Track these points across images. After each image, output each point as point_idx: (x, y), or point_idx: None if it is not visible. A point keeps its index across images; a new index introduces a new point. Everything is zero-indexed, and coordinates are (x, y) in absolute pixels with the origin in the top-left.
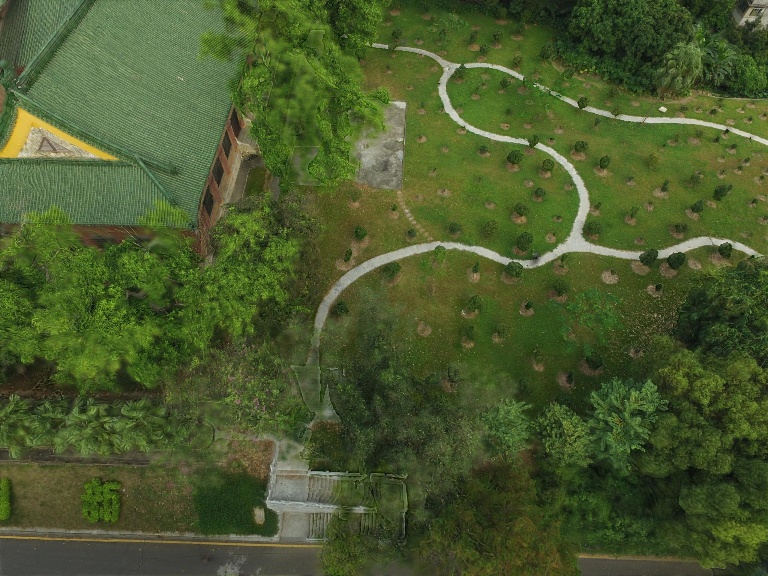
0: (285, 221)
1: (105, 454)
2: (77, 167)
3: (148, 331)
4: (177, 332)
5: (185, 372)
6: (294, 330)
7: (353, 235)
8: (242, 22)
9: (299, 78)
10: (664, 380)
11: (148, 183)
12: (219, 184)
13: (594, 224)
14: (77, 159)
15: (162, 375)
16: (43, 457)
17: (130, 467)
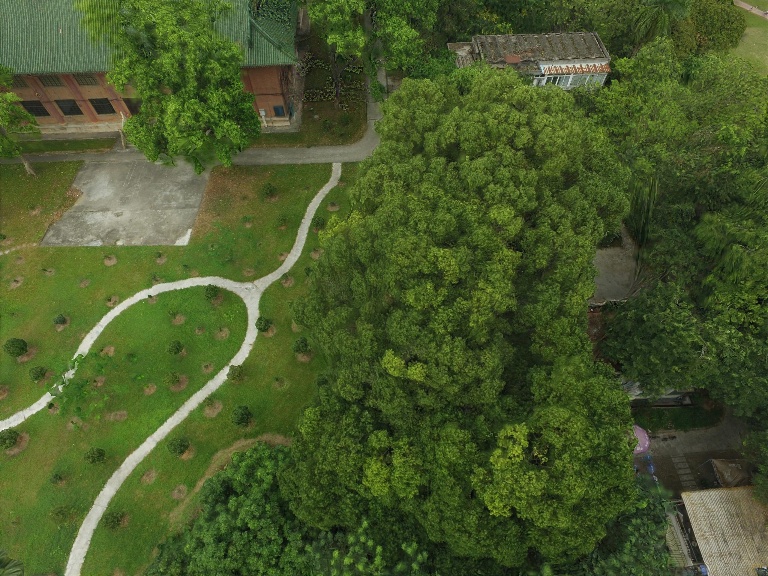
0: None
1: None
2: None
3: None
4: None
5: None
6: None
7: None
8: None
9: (250, 151)
10: None
11: None
12: (70, 115)
13: None
14: None
15: None
16: None
17: None
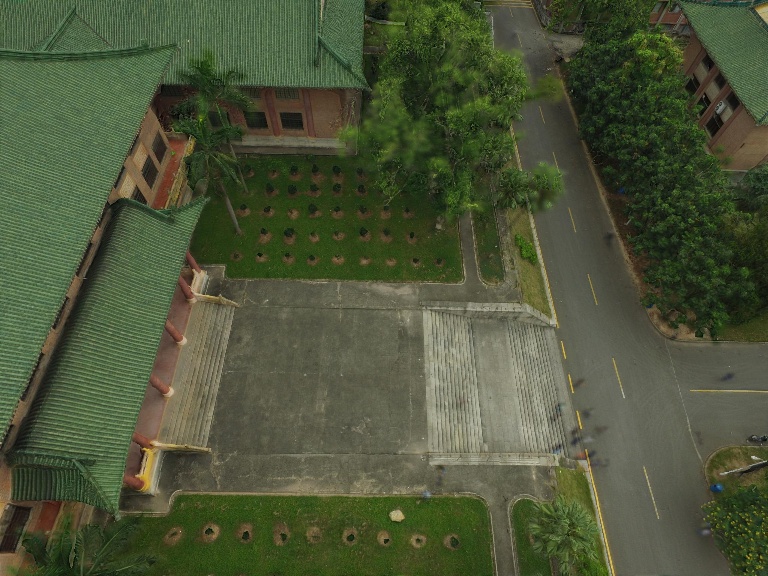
0: None
1: None
2: (327, 6)
3: None
4: None
5: None
6: (395, 31)
7: None
8: None
9: None
10: None
11: None
12: None
13: None
14: None
15: None
16: None
17: None
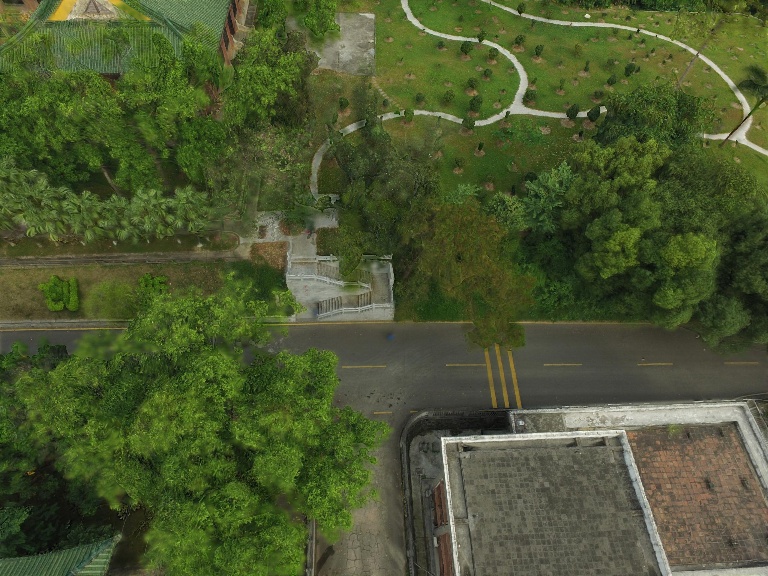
0: (291, 48)
1: (160, 237)
2: None
3: (193, 127)
4: (214, 131)
5: (222, 160)
6: None
7: (337, 108)
8: None
9: None
10: (576, 166)
11: (175, 39)
12: (222, 70)
13: (531, 91)
14: (116, 21)
15: (205, 162)
16: (103, 259)
17: (175, 263)
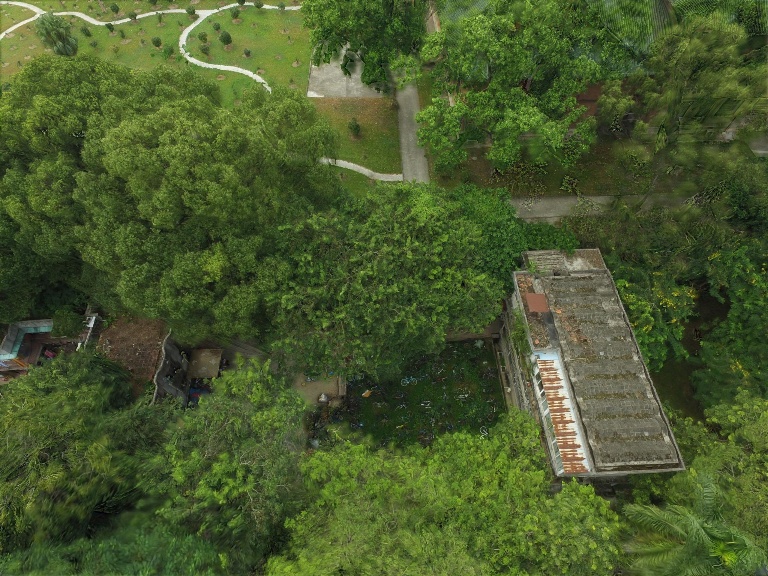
0: None
1: None
2: None
3: None
4: None
5: None
6: None
7: None
8: (453, 13)
9: None
10: None
11: None
12: None
13: (191, 8)
14: None
15: None
16: None
17: None
